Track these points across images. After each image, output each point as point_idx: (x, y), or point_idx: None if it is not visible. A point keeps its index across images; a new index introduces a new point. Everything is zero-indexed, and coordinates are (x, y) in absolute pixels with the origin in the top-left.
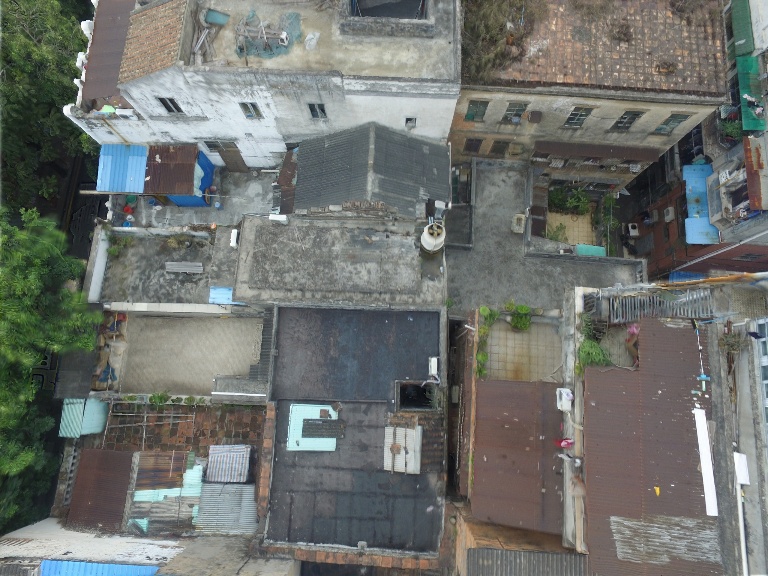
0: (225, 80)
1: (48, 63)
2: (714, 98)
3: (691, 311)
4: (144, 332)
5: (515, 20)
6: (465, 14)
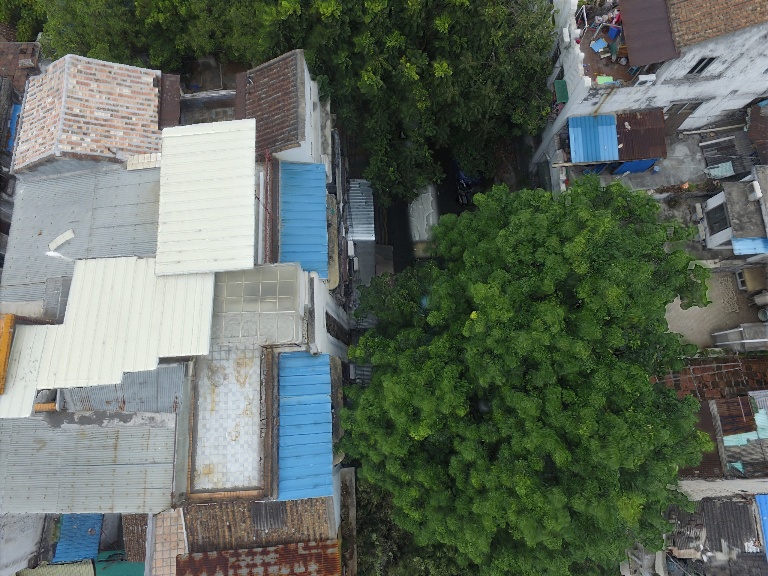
0: None
1: (523, 43)
2: None
3: None
4: None
5: None
6: None
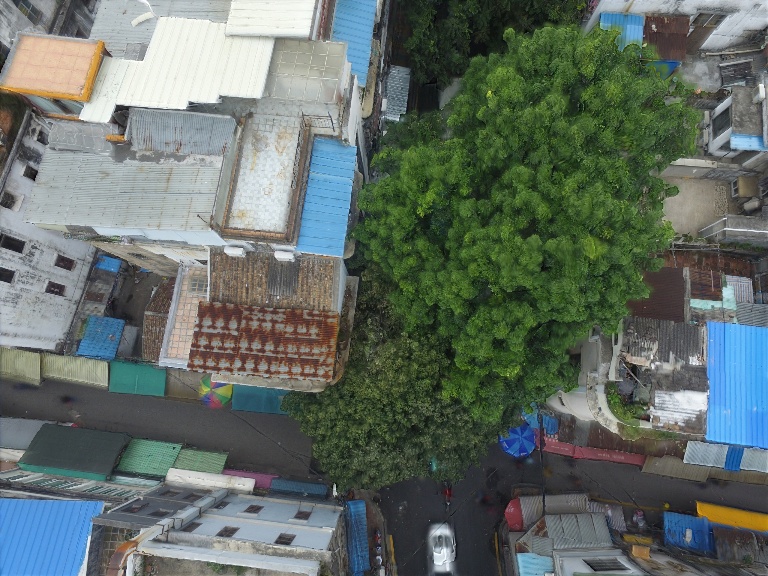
0: None
1: None
2: None
3: None
4: None
5: None
6: None
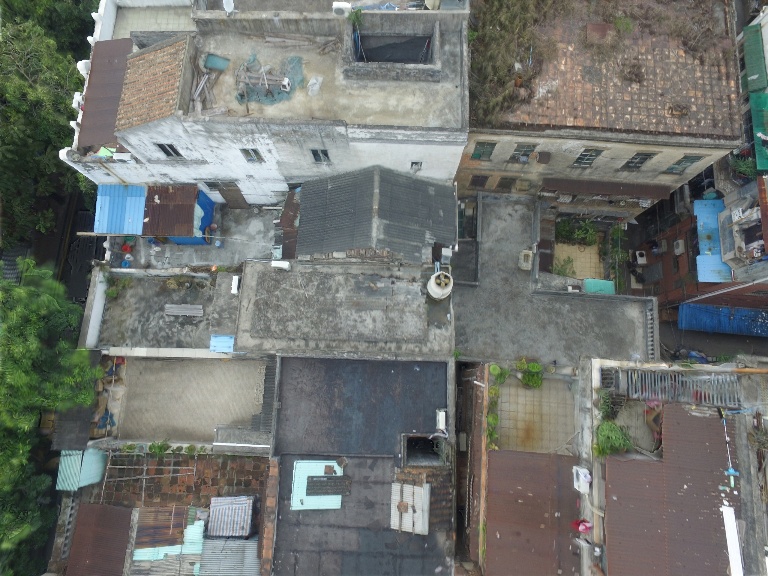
0: (225, 129)
1: (44, 103)
2: (729, 141)
3: (717, 397)
4: (143, 375)
5: (523, 61)
6: (472, 54)
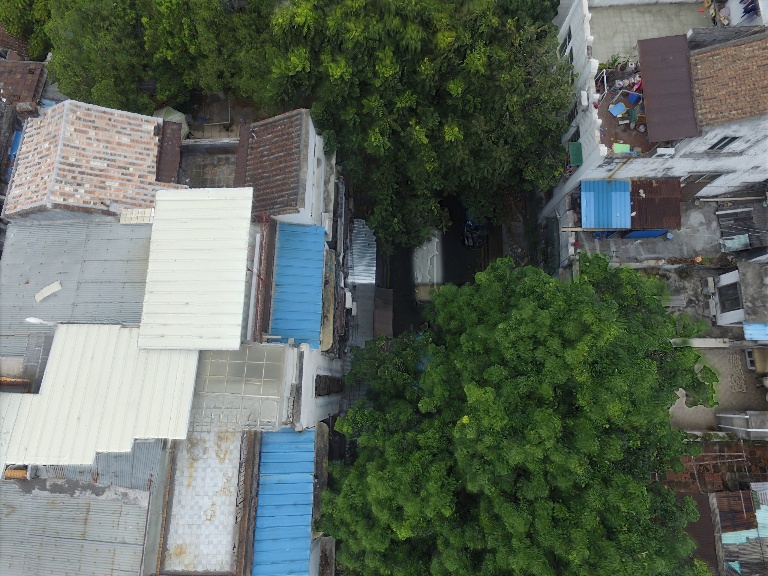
0: None
1: (539, 103)
2: None
3: None
4: None
5: None
6: None
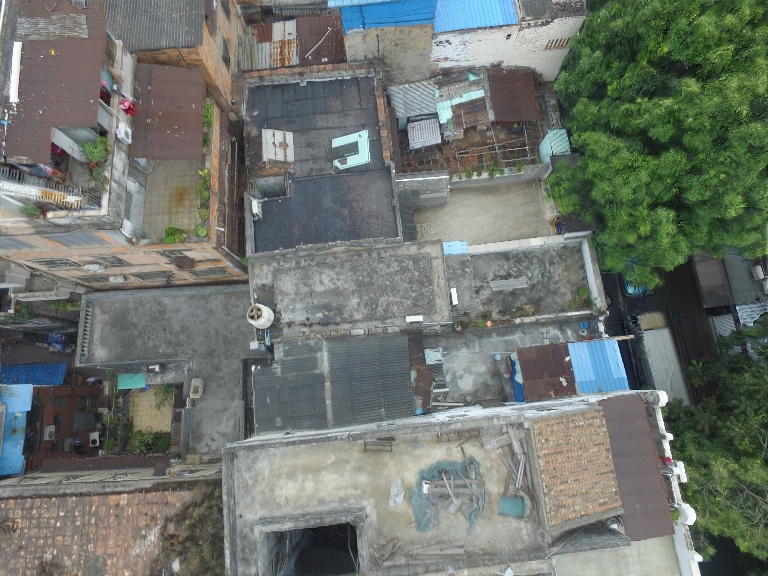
0: None
1: None
2: None
3: (6, 173)
4: (534, 231)
5: (170, 575)
6: None
